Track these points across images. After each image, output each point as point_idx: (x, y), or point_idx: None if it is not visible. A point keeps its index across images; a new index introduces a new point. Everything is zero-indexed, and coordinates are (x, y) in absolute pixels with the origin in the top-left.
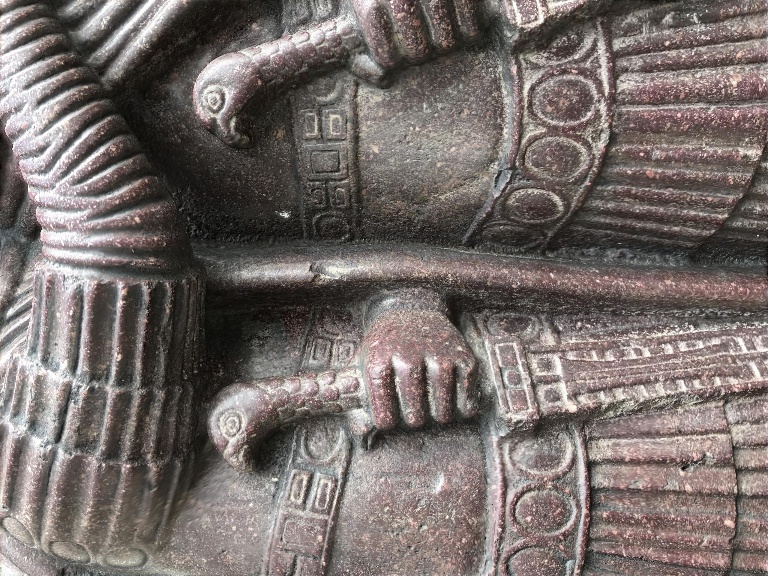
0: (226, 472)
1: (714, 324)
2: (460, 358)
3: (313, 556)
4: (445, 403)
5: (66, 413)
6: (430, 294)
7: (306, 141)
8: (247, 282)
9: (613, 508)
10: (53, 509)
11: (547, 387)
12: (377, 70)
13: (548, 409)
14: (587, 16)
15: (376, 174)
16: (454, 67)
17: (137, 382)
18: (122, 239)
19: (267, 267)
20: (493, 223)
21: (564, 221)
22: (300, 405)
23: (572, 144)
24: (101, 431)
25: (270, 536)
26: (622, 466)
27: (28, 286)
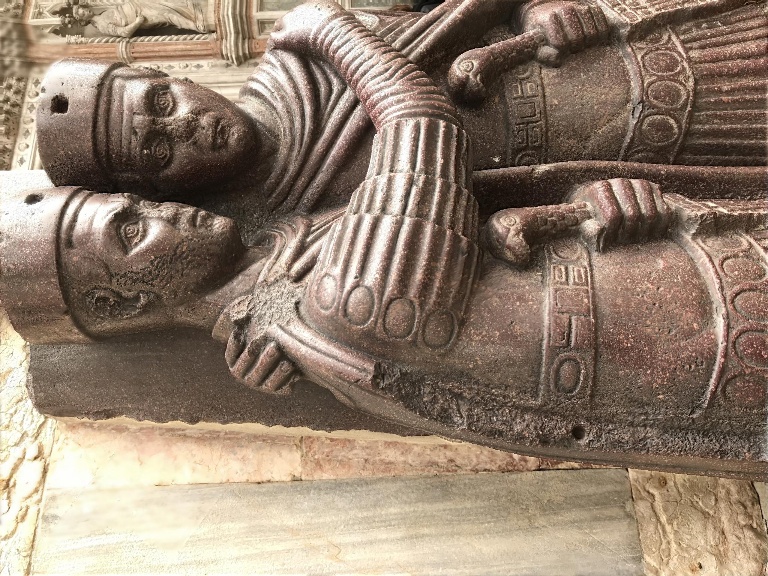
0: (502, 272)
1: None
2: None
3: (583, 315)
4: (650, 201)
5: (409, 195)
6: None
7: (514, 100)
8: (489, 175)
9: None
10: (399, 262)
11: None
12: (555, 51)
13: None
14: (662, 23)
15: (557, 119)
16: (595, 54)
17: (452, 180)
18: (438, 103)
19: None
20: (634, 150)
21: (680, 142)
22: (550, 215)
23: (674, 85)
24: (432, 207)
25: (547, 304)
26: None
27: (320, 220)
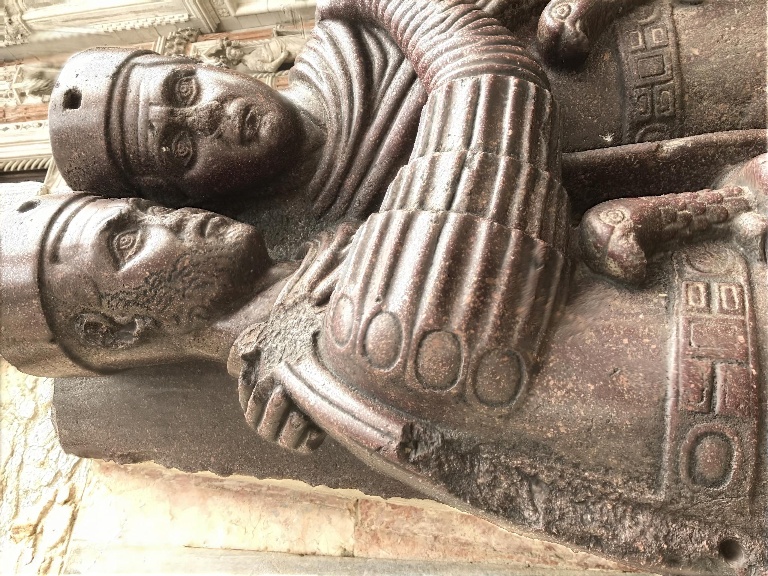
0: (603, 292)
1: None
2: None
3: (736, 362)
4: None
5: (459, 181)
6: None
7: (632, 54)
8: (591, 156)
9: None
10: (438, 278)
11: None
12: None
13: None
14: None
15: (698, 76)
16: None
17: (524, 158)
18: (510, 55)
19: None
20: None
21: None
22: (681, 207)
23: None
24: (491, 198)
25: (674, 343)
26: None
27: None
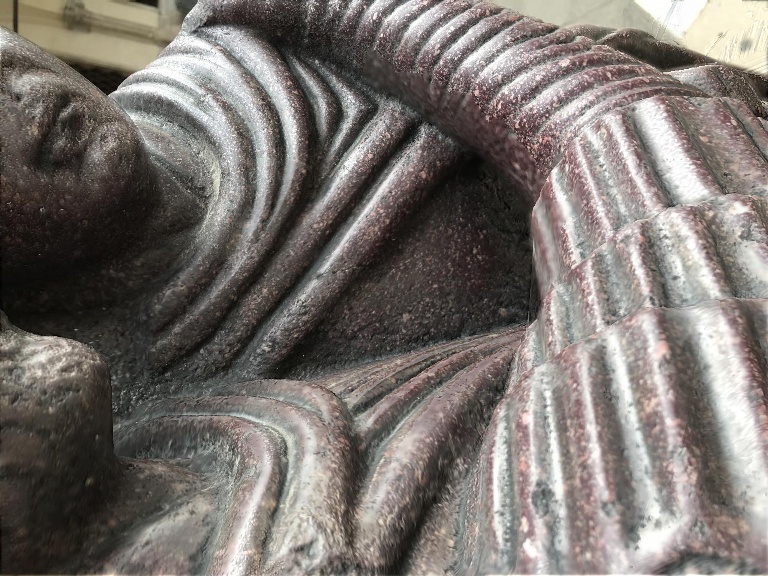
0: None
1: None
2: None
3: None
4: None
5: None
6: None
7: None
8: None
9: None
10: None
11: None
12: None
13: None
14: None
15: None
16: None
17: None
18: None
19: None
20: None
21: None
22: None
23: None
24: None
25: None
26: None
27: (344, 386)
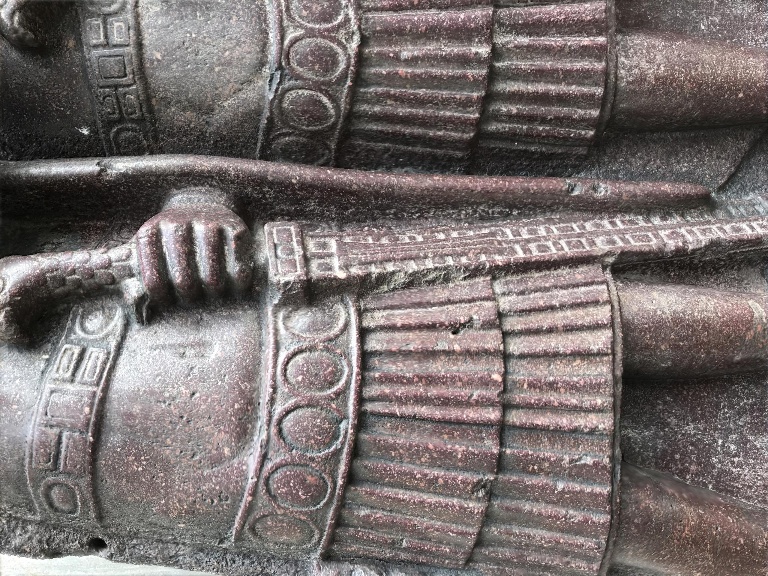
0: None
1: (487, 223)
2: (228, 223)
3: (79, 431)
4: (212, 262)
5: None
6: (217, 192)
7: (94, 48)
8: (34, 176)
9: (387, 370)
10: None
11: (321, 261)
12: None
13: (318, 275)
14: None
15: (162, 81)
16: None
17: None
18: None
19: (56, 164)
20: (277, 133)
21: (340, 128)
22: (70, 272)
23: (329, 45)
24: None
25: (35, 412)
26: (395, 333)
27: None
